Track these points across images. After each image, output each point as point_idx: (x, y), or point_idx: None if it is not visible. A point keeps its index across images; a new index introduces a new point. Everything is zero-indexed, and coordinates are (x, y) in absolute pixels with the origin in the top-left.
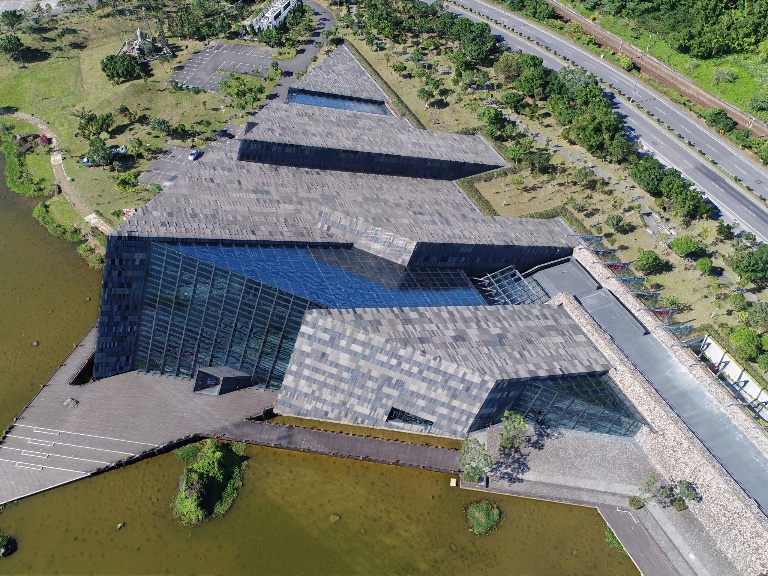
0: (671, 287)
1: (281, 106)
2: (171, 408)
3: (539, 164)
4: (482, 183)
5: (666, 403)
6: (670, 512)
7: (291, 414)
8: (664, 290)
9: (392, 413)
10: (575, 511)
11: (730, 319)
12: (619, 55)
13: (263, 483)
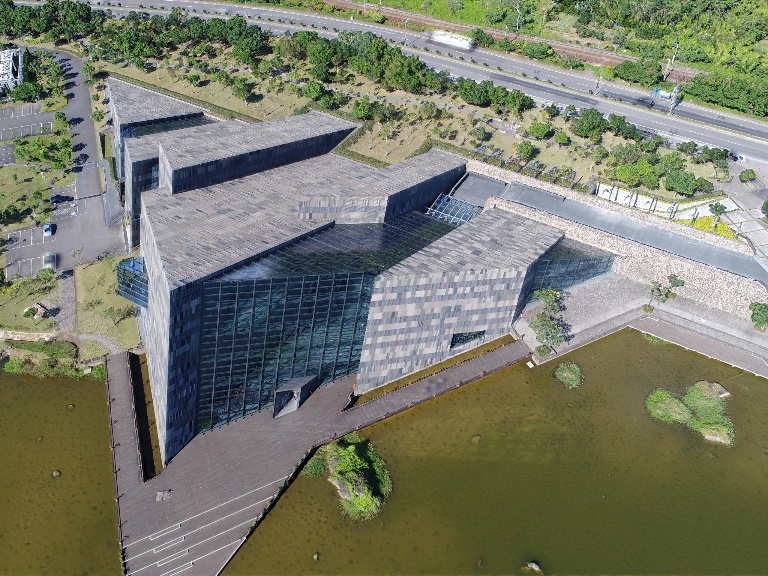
0: (550, 163)
1: (138, 141)
2: (267, 442)
3: (389, 113)
4: (353, 146)
5: (617, 236)
6: (670, 303)
7: (370, 389)
8: (547, 167)
9: (453, 340)
10: (617, 336)
11: (601, 167)
12: (368, 12)
13: (400, 450)
